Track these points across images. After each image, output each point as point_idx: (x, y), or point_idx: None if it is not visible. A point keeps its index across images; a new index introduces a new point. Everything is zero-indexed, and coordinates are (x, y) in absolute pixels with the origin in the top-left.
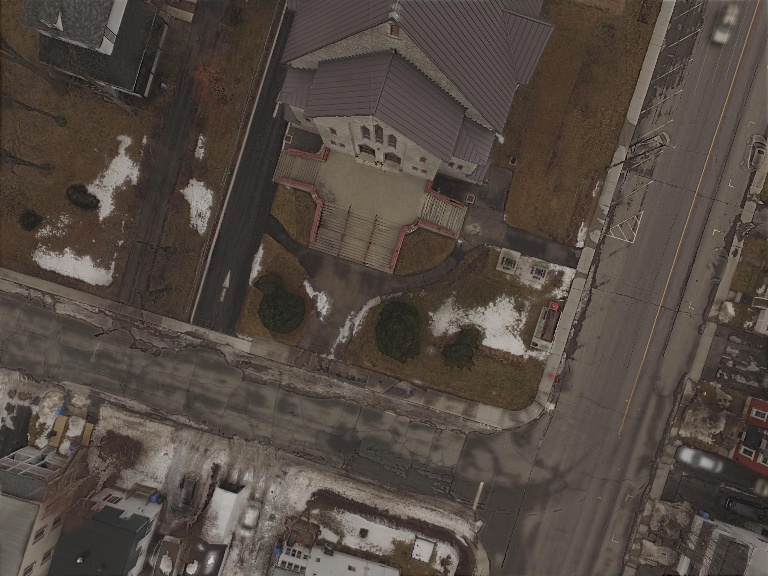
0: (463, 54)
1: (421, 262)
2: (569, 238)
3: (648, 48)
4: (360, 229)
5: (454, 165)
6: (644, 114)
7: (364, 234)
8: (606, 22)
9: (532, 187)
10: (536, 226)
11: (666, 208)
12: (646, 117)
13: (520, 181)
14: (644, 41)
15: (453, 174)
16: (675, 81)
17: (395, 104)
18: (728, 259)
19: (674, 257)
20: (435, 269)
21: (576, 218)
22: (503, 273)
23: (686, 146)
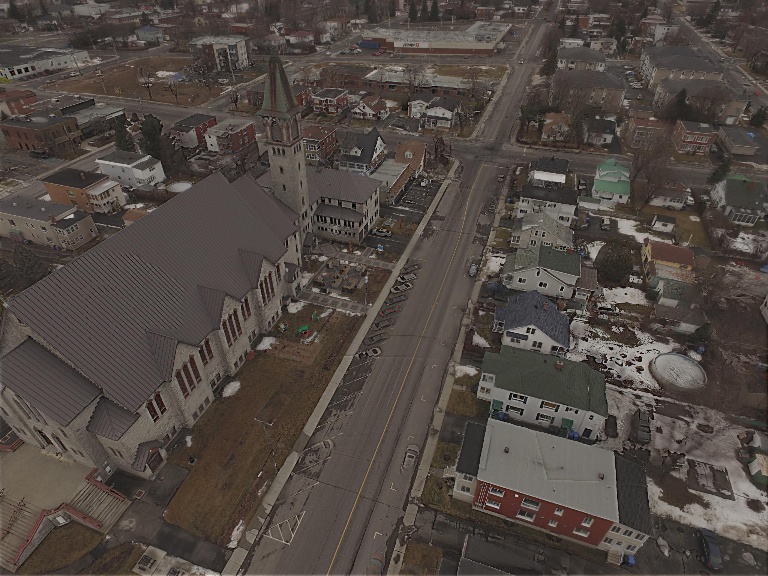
0: (87, 344)
1: (54, 559)
2: (222, 536)
3: (328, 385)
4: (6, 516)
5: (115, 452)
6: (319, 428)
7: (7, 522)
8: (299, 369)
9: (202, 484)
10: (193, 523)
11: (328, 508)
12: (321, 431)
13: (193, 479)
14: (326, 380)
15: (128, 468)
16: (347, 406)
17: (15, 369)
18: (389, 566)
19: (331, 562)
20: (65, 568)
21: (235, 515)
22: (138, 575)
23: (352, 453)
